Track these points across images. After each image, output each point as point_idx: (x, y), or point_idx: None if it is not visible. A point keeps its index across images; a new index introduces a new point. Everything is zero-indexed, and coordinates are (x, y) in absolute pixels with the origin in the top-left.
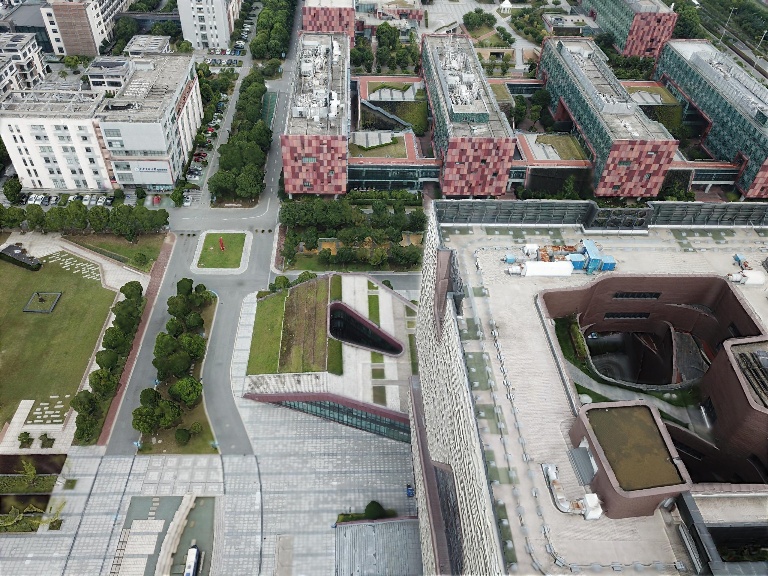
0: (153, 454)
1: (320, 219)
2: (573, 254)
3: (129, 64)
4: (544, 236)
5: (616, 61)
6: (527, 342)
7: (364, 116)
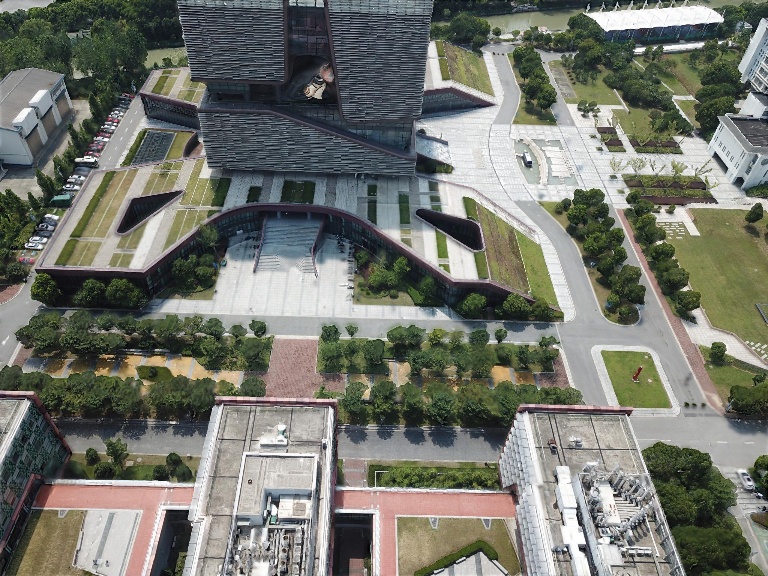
0: None
1: None
2: None
3: None
4: None
5: None
6: None
7: None
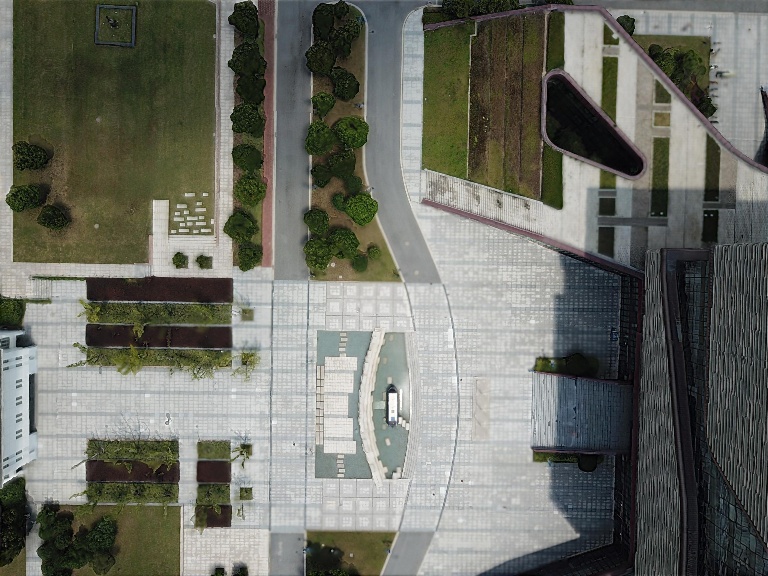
0: (329, 280)
1: None
2: None
3: None
4: None
5: None
6: None
7: None
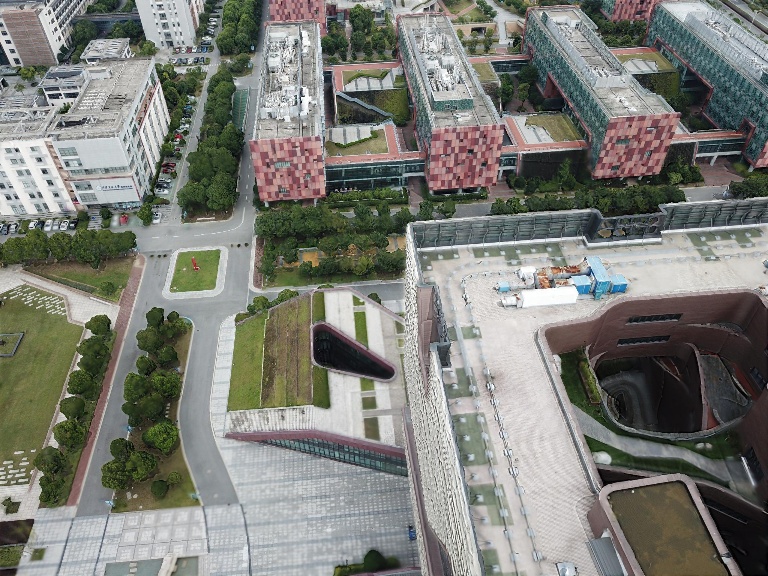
0: (128, 511)
1: (299, 228)
2: (576, 276)
3: (83, 74)
4: (541, 254)
5: (605, 27)
6: (529, 395)
7: (341, 109)
